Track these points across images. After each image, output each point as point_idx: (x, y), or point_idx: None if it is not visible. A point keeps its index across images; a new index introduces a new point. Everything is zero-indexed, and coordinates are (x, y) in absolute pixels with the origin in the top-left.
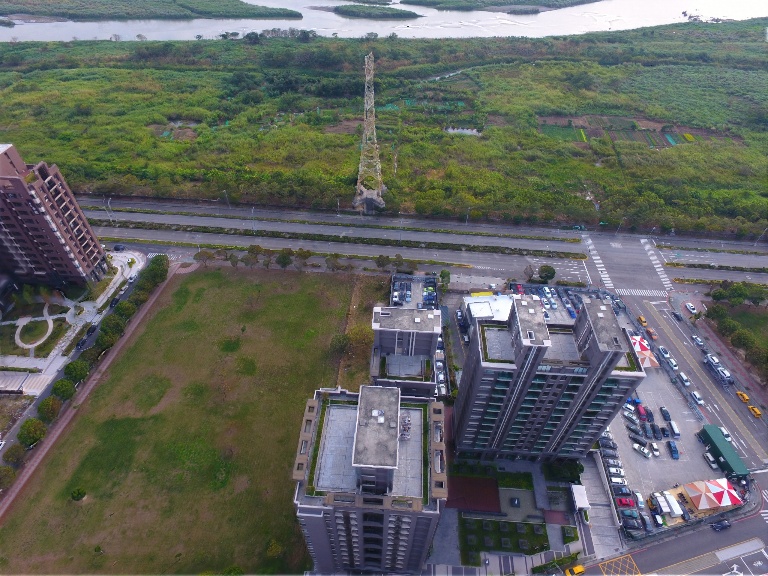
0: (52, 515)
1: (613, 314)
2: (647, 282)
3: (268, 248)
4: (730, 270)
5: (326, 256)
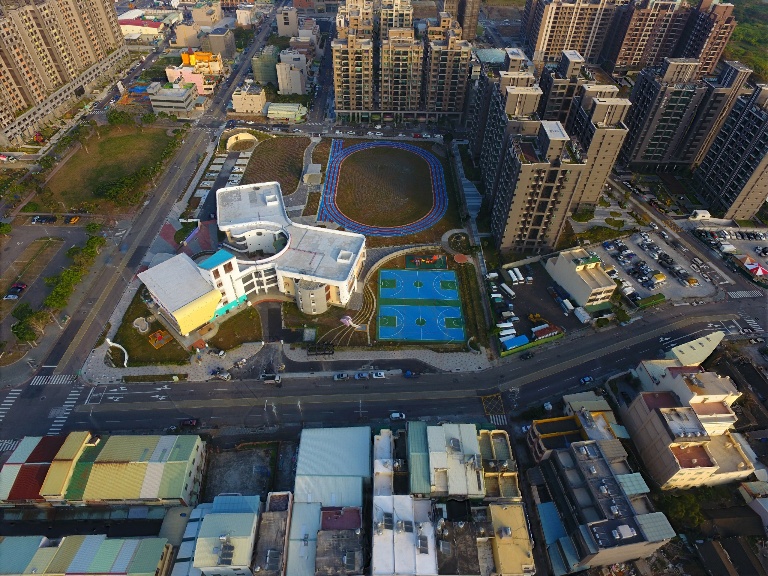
0: None
1: None
2: None
3: None
4: None
5: None
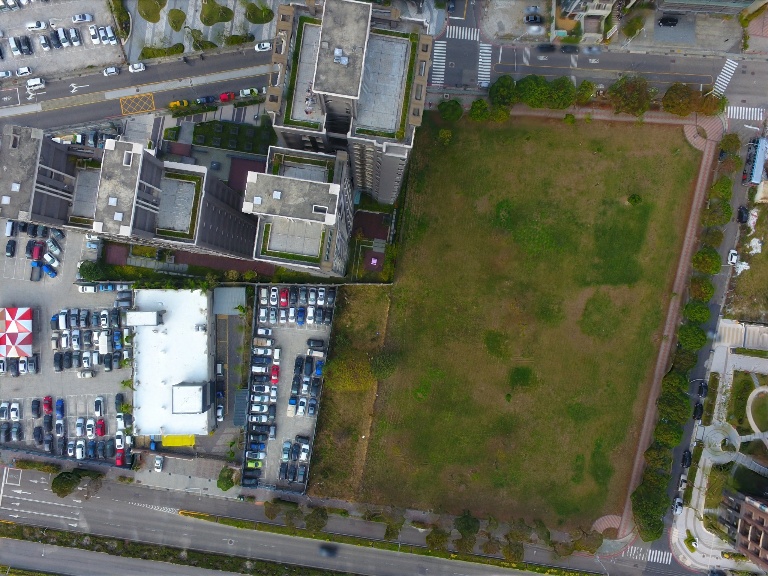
0: (651, 189)
1: None
2: None
3: (494, 569)
4: None
5: (404, 546)
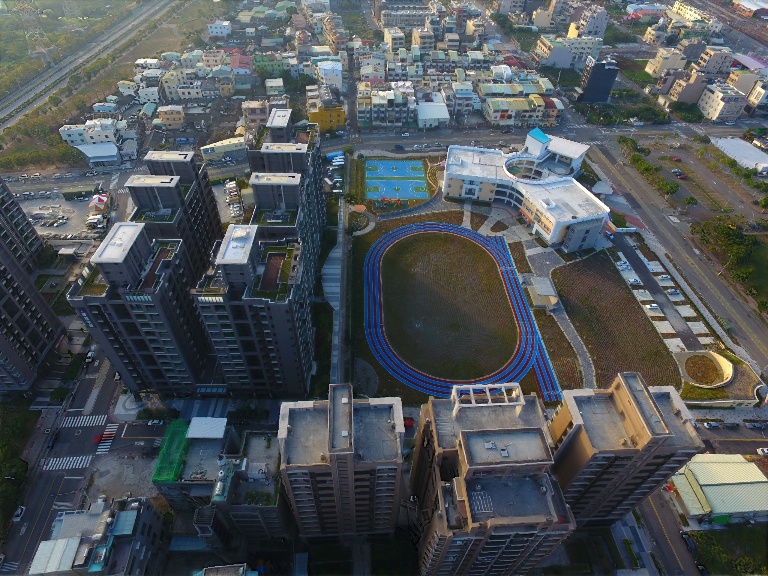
0: None
1: None
2: None
3: None
4: None
5: None
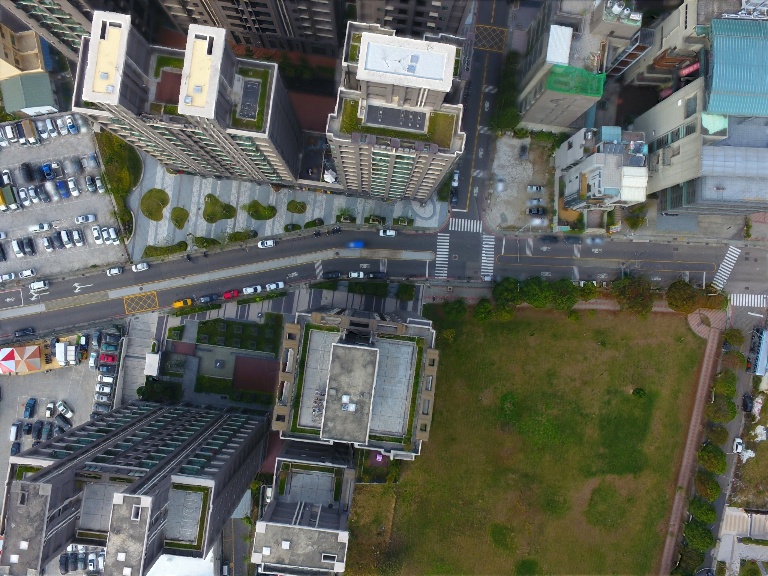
0: (655, 377)
1: (5, 546)
2: None
3: None
4: None
5: None
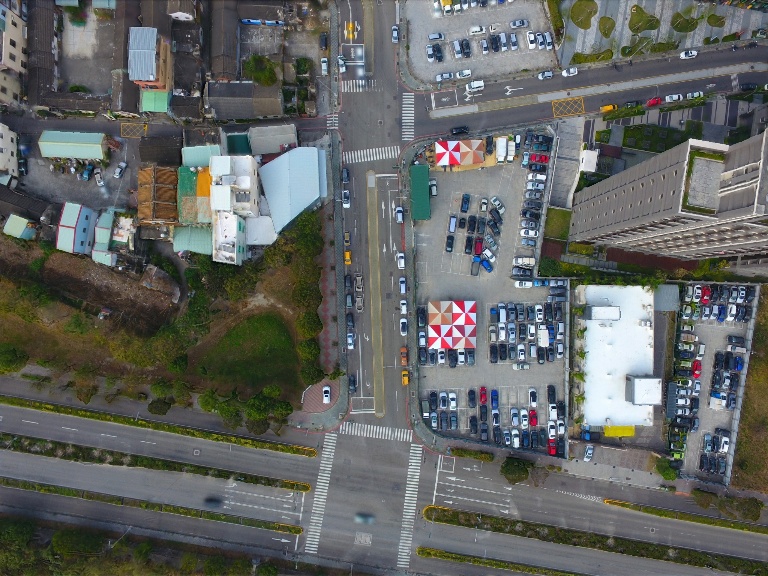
0: None
1: (762, 187)
2: (358, 452)
3: None
4: (216, 469)
5: None
